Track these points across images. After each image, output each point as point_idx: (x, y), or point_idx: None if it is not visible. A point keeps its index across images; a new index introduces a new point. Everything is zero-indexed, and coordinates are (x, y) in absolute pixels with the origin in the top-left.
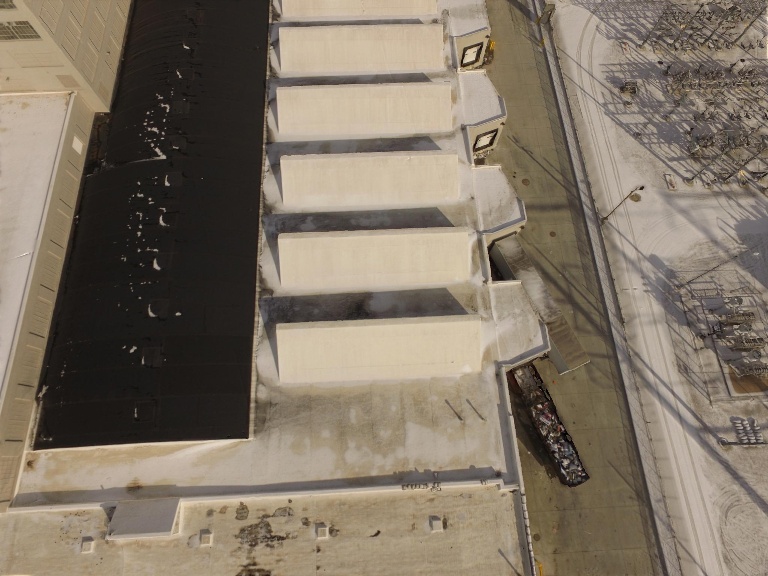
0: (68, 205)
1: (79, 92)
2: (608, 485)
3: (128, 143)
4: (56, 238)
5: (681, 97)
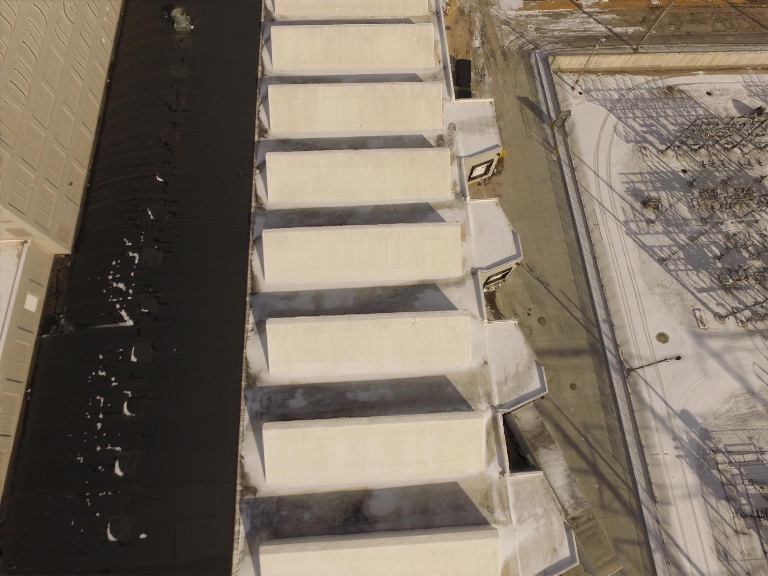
0: (18, 381)
1: (34, 240)
2: None
3: (90, 300)
4: (1, 429)
5: (709, 216)
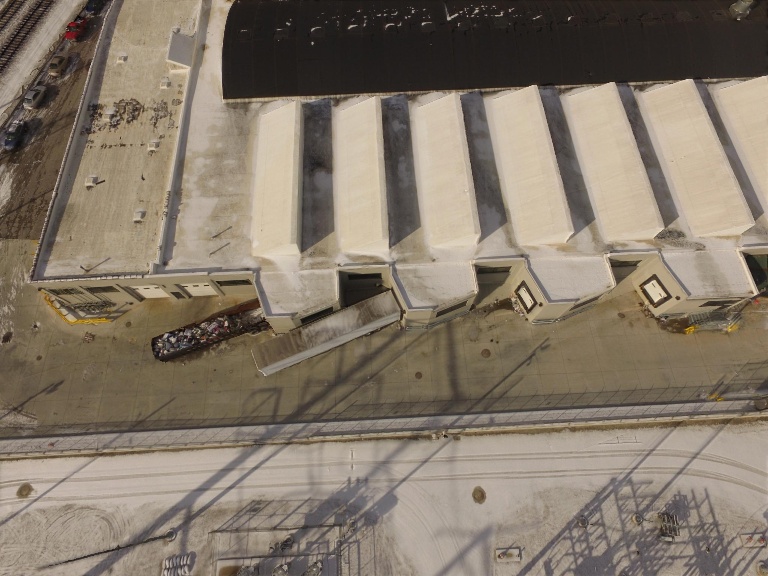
0: None
1: None
2: (155, 394)
3: (465, 1)
4: None
5: None
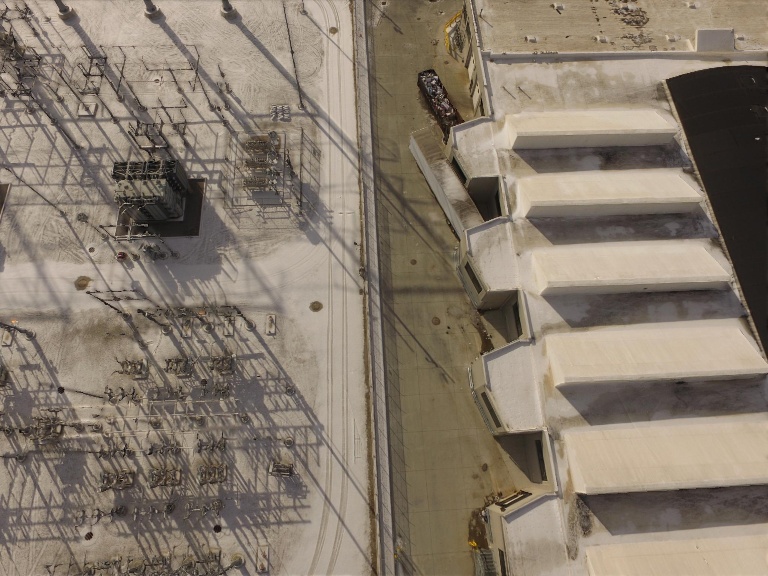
0: None
1: None
2: (395, 85)
3: None
4: None
5: None
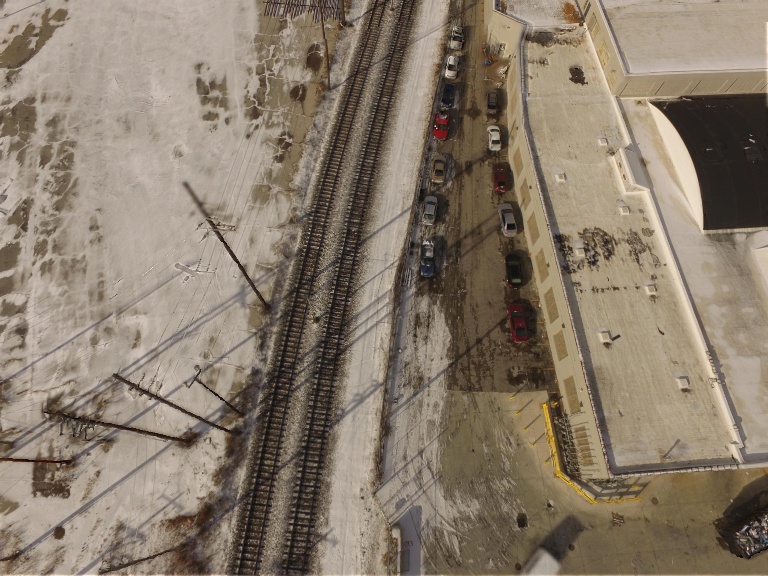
0: None
1: None
2: None
3: None
4: None
5: None
